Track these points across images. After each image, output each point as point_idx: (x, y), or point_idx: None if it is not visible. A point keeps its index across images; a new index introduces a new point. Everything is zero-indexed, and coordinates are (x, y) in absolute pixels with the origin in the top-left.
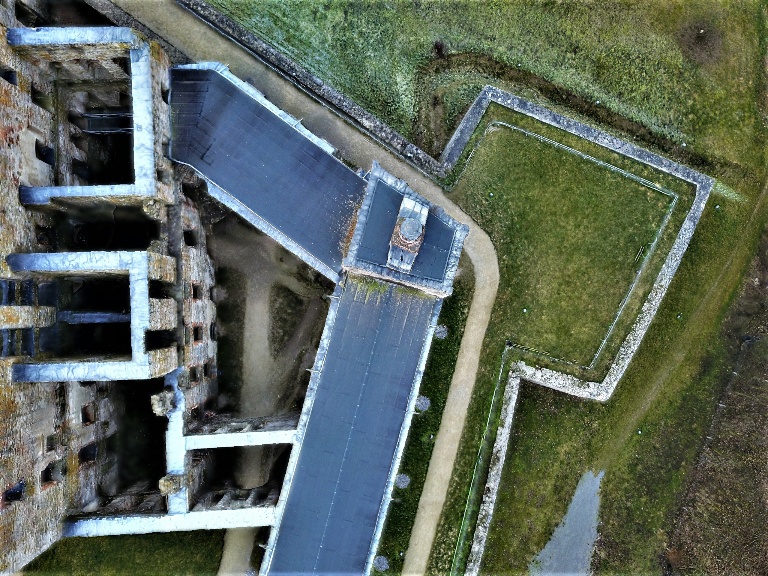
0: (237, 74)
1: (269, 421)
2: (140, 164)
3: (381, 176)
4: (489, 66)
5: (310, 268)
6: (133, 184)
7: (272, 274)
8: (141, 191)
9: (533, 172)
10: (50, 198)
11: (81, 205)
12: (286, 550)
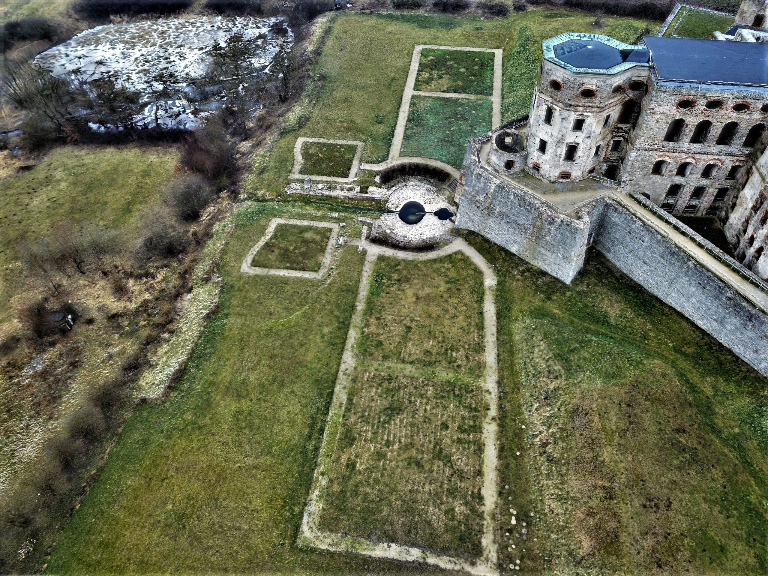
0: None
1: None
2: None
3: None
4: None
5: None
6: None
7: None
8: None
9: None
10: None
11: None
12: None
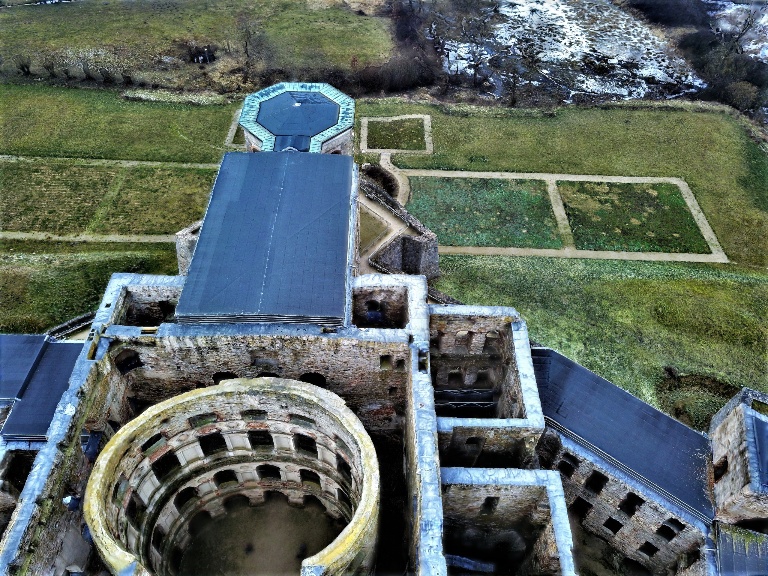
0: None
1: None
2: (530, 403)
3: (754, 415)
4: (714, 387)
5: (616, 553)
6: (526, 418)
7: (577, 558)
8: (534, 424)
9: None
10: (453, 427)
11: (455, 446)
12: None
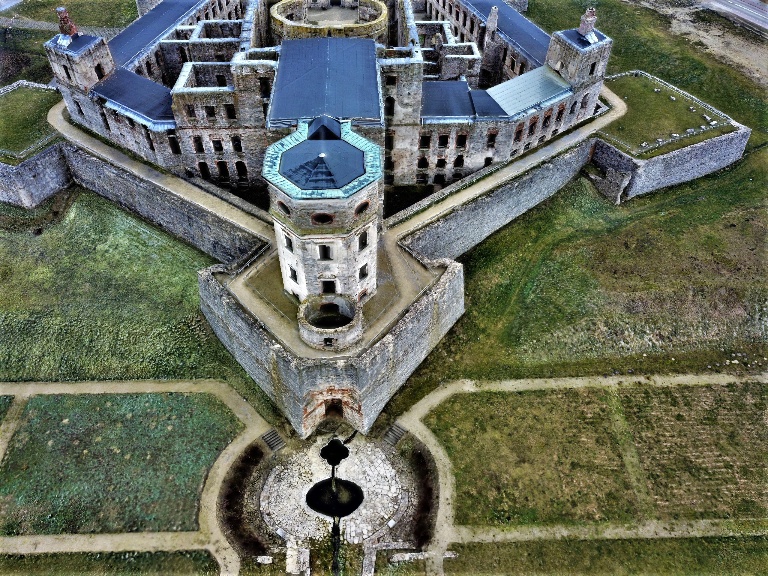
0: (164, 178)
1: (179, 62)
2: (188, 68)
3: (74, 54)
4: None
5: None
6: (193, 64)
7: None
8: None
9: (8, 141)
10: None
11: None
12: (173, 18)
